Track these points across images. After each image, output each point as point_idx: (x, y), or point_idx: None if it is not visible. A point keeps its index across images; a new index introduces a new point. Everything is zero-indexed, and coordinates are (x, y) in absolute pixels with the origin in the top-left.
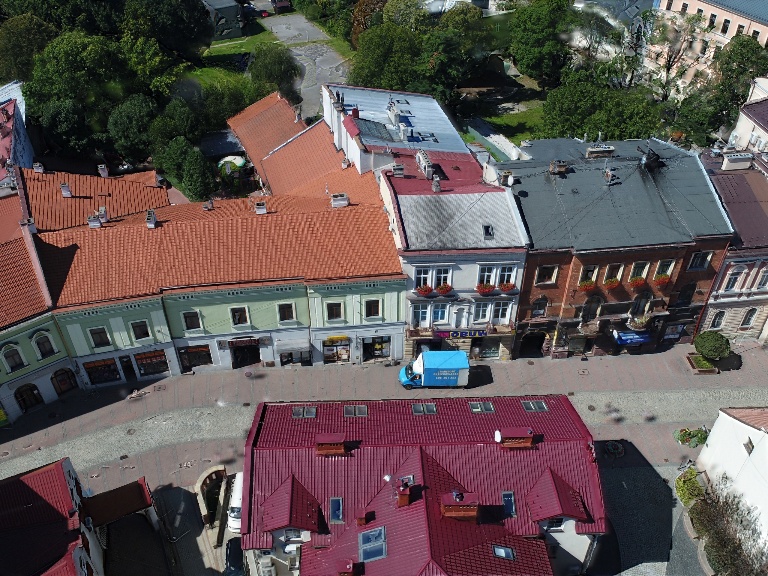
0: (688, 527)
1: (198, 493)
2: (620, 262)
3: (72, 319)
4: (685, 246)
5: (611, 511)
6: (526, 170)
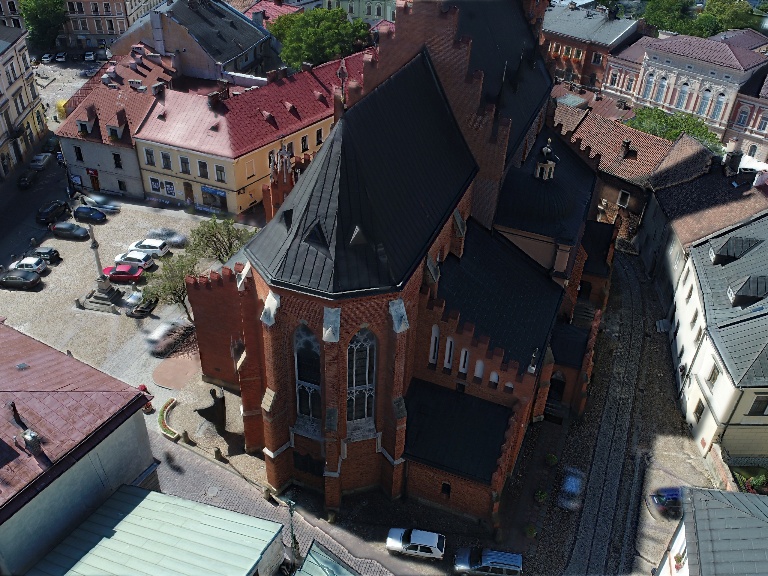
0: None
1: None
2: (560, 43)
3: (390, 4)
4: (585, 42)
5: None
6: (562, 4)
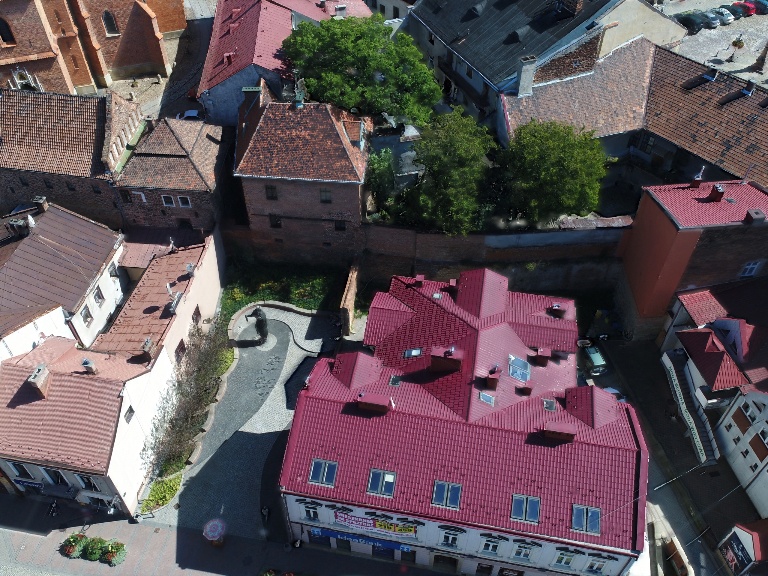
0: (199, 451)
1: (690, 564)
2: None
3: None
4: None
5: (256, 485)
6: None
